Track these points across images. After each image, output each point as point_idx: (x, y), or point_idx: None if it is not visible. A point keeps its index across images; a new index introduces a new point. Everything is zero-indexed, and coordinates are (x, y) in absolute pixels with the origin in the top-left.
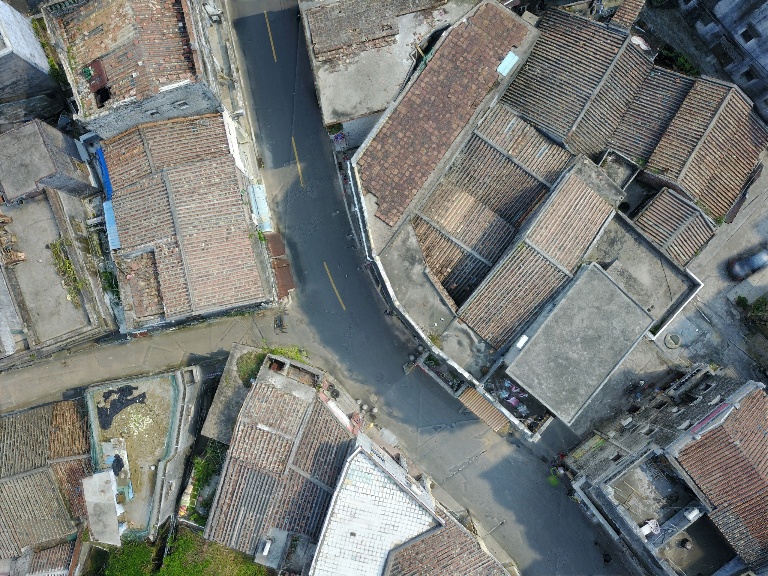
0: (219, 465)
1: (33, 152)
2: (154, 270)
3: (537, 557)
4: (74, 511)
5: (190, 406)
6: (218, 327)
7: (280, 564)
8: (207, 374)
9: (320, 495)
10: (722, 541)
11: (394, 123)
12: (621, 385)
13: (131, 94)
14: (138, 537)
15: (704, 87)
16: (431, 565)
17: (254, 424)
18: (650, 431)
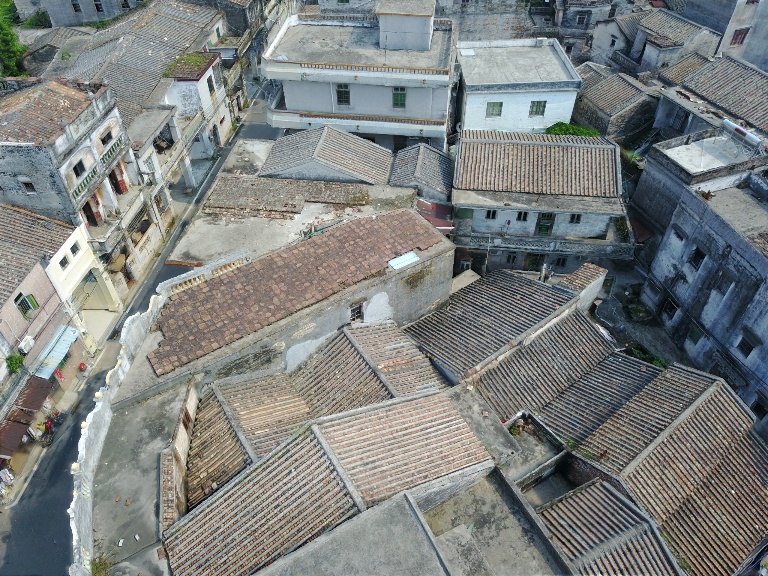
0: None
1: None
2: None
3: None
4: None
5: None
6: None
7: None
8: None
9: None
10: None
11: (240, 274)
12: None
13: None
14: None
15: (676, 375)
16: None
17: None
18: None
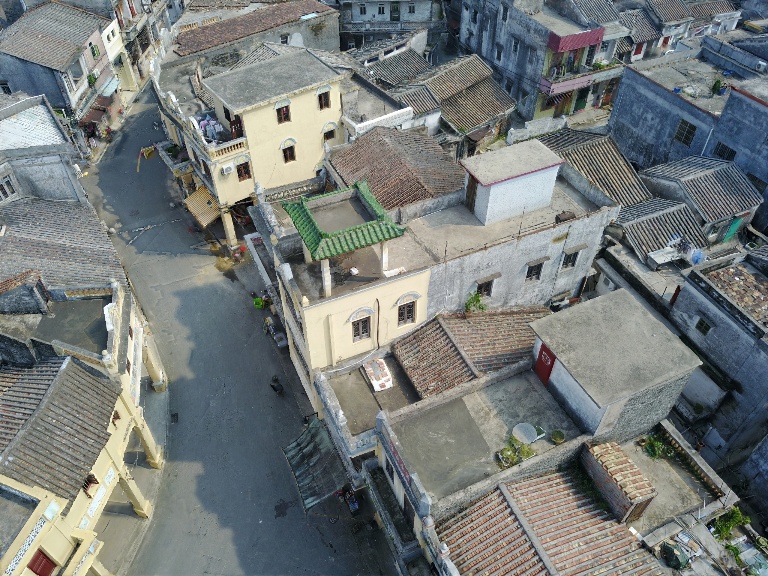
0: None
1: None
2: None
3: (197, 380)
4: None
5: None
6: None
7: None
8: None
9: None
10: None
11: (217, 24)
12: None
13: None
14: None
15: None
16: (45, 225)
17: None
18: None
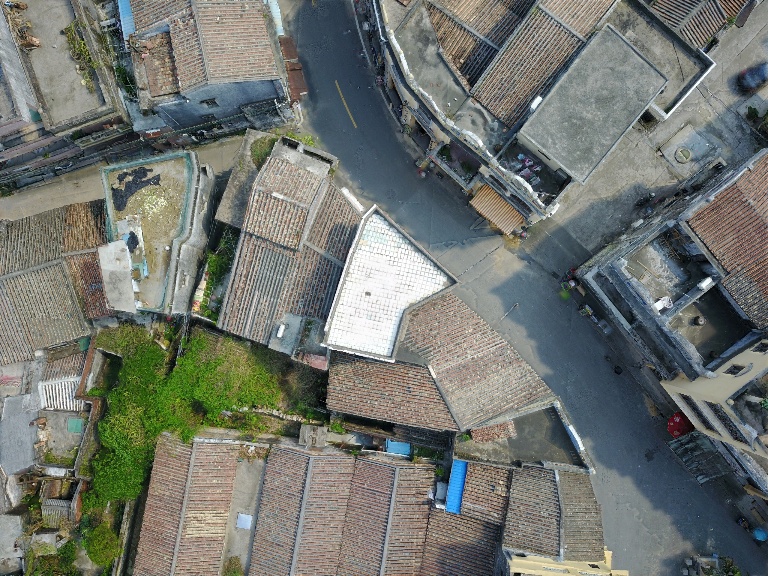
0: (232, 259)
1: None
2: (169, 50)
3: (548, 372)
4: (88, 311)
5: (204, 198)
6: (230, 146)
7: None
8: None
9: (334, 272)
10: (734, 319)
11: None
12: (632, 200)
13: None
14: None
15: None
16: (445, 341)
17: (269, 192)
18: None
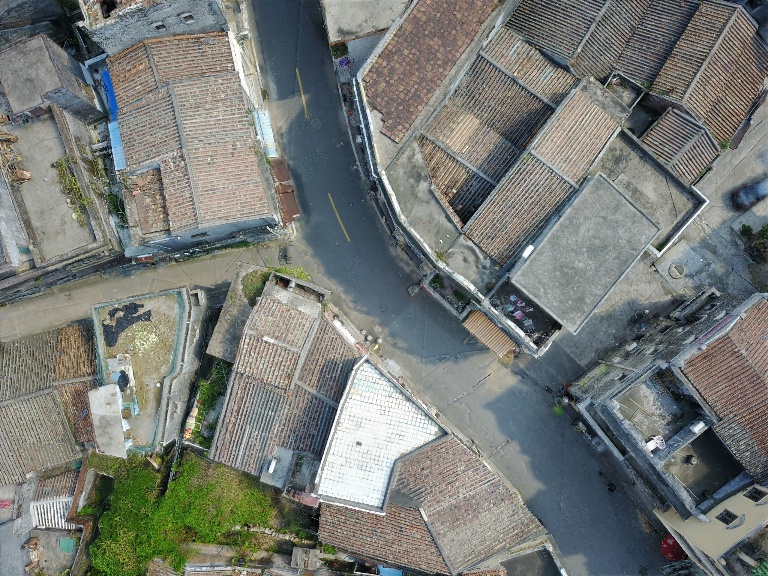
0: (224, 387)
1: (39, 67)
2: (160, 187)
3: (542, 487)
4: (79, 436)
5: (195, 328)
6: (223, 259)
7: (285, 483)
8: (212, 305)
9: (326, 411)
10: (727, 458)
11: (399, 40)
12: (625, 315)
13: (137, 2)
14: (143, 464)
15: (709, 9)
16: (436, 481)
17: (260, 336)
18: (655, 351)
